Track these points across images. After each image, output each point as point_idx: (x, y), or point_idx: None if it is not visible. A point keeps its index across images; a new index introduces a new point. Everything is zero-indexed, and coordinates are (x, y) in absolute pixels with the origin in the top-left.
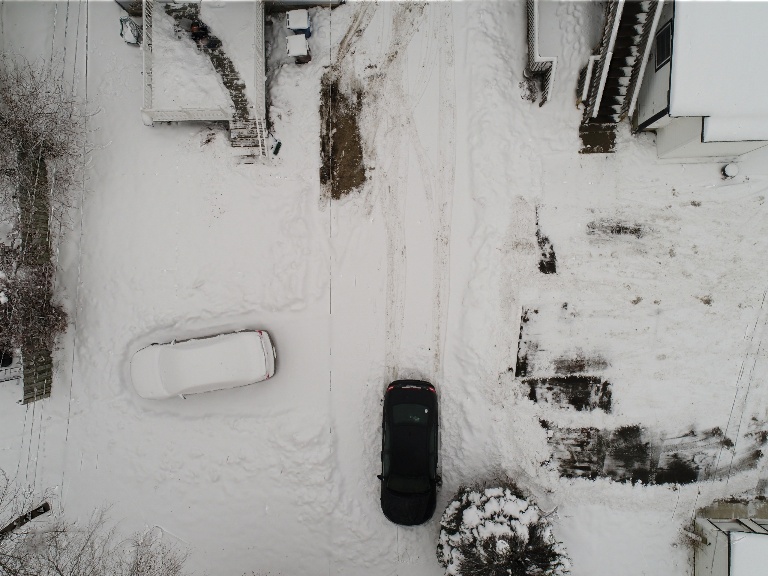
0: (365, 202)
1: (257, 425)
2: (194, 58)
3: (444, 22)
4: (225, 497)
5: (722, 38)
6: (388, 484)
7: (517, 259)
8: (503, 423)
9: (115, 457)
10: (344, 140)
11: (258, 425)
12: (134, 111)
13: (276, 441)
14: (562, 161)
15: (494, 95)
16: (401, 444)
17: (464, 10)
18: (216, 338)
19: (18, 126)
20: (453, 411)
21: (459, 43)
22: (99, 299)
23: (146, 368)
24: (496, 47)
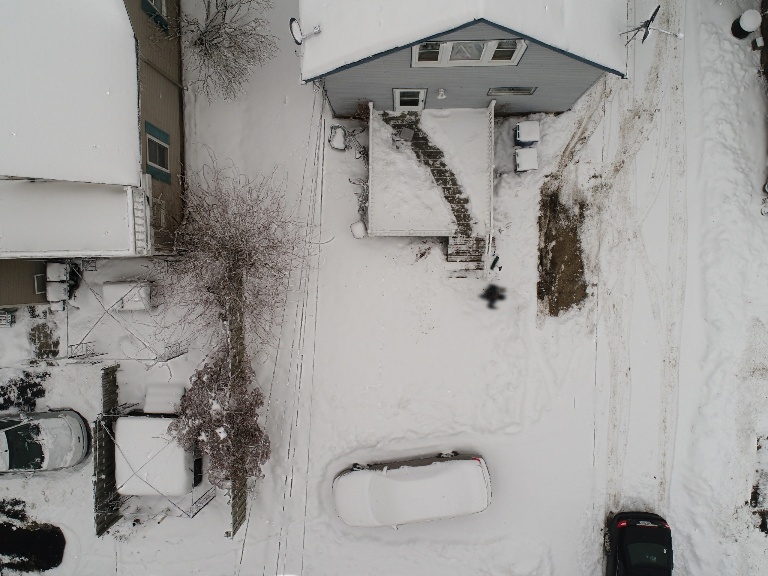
0: (586, 320)
1: (466, 553)
2: (415, 171)
3: (676, 130)
4: None
5: None
6: None
7: (754, 386)
8: (735, 557)
9: None
10: (564, 253)
11: (468, 553)
12: (337, 219)
13: (489, 571)
14: None
15: (734, 212)
16: None
17: (699, 118)
18: (433, 467)
19: (233, 246)
20: (679, 543)
21: (693, 153)
22: None
23: (354, 495)
24: (736, 160)
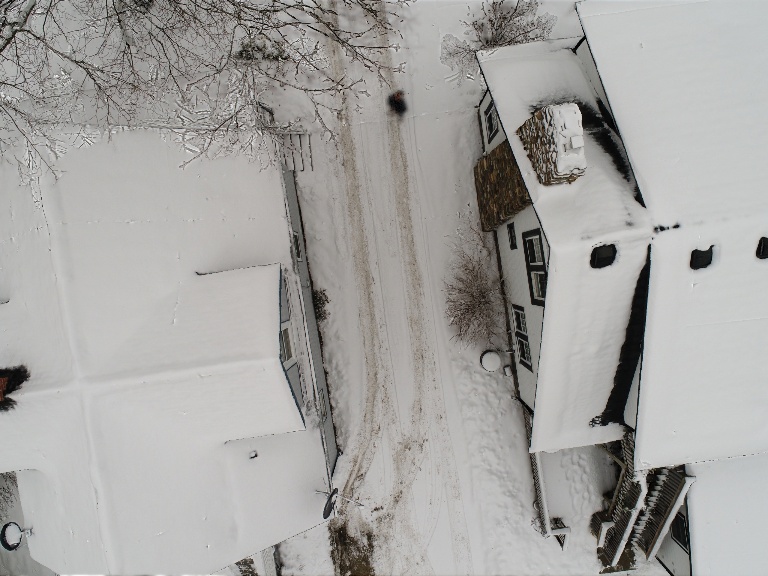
0: None
1: None
2: None
3: (445, 457)
4: None
5: (741, 558)
6: None
7: None
8: None
9: None
10: None
11: None
12: None
13: None
14: None
15: (507, 534)
16: None
17: (464, 445)
18: None
19: None
20: None
21: (464, 478)
22: None
23: None
24: (502, 484)
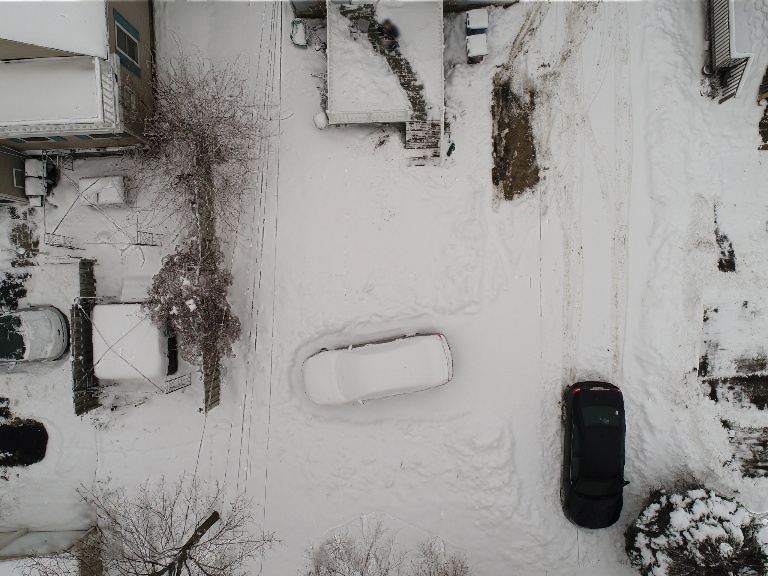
0: None
1: (431, 430)
2: (372, 59)
3: (618, 19)
4: (399, 503)
5: None
6: (576, 487)
7: (699, 258)
8: (686, 424)
9: (285, 464)
10: (516, 140)
11: (432, 430)
12: (301, 114)
13: (453, 445)
14: (741, 158)
15: (674, 92)
16: (593, 447)
17: (640, 7)
18: (396, 342)
19: (200, 131)
20: (633, 412)
21: (635, 40)
22: (266, 305)
23: (322, 374)
24: (675, 44)
